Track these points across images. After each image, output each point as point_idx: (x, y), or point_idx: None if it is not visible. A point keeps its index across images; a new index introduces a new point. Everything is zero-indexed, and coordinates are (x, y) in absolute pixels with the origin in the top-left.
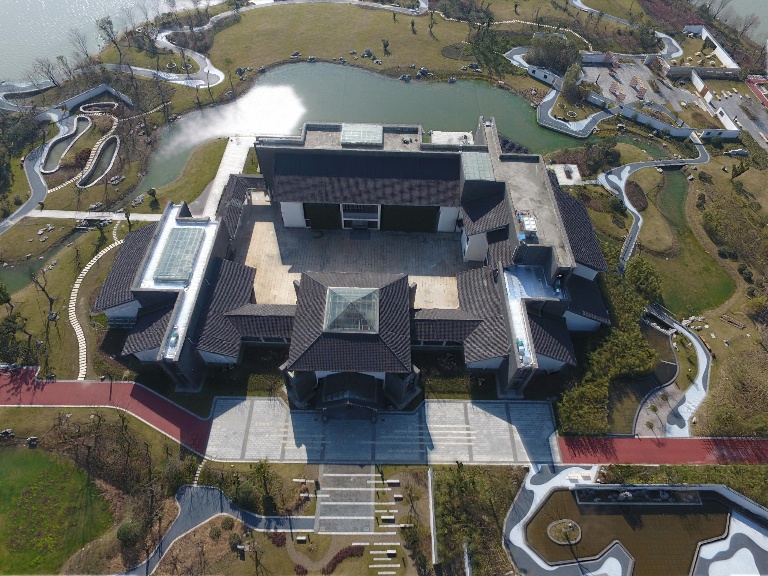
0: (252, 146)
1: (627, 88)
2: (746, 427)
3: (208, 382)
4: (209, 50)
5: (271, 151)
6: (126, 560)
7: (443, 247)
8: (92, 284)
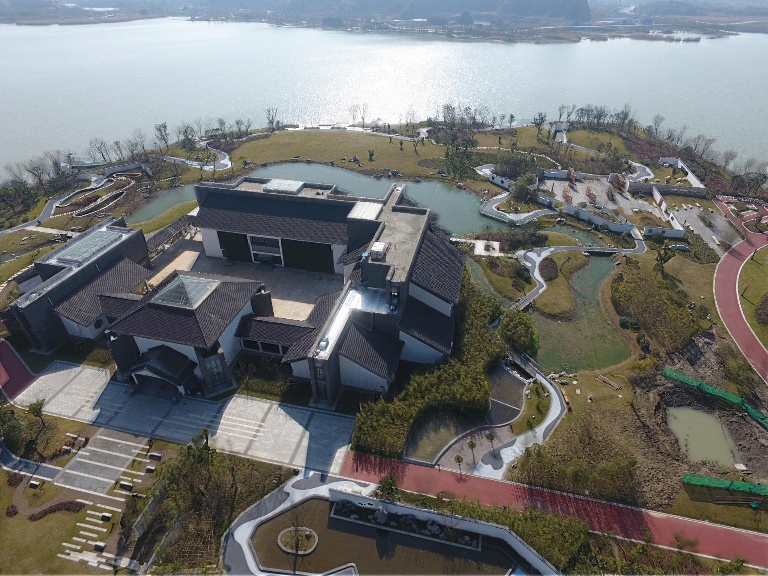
0: None
1: (582, 196)
2: (560, 471)
3: (59, 348)
4: (233, 151)
5: (205, 190)
6: None
7: (333, 285)
8: None
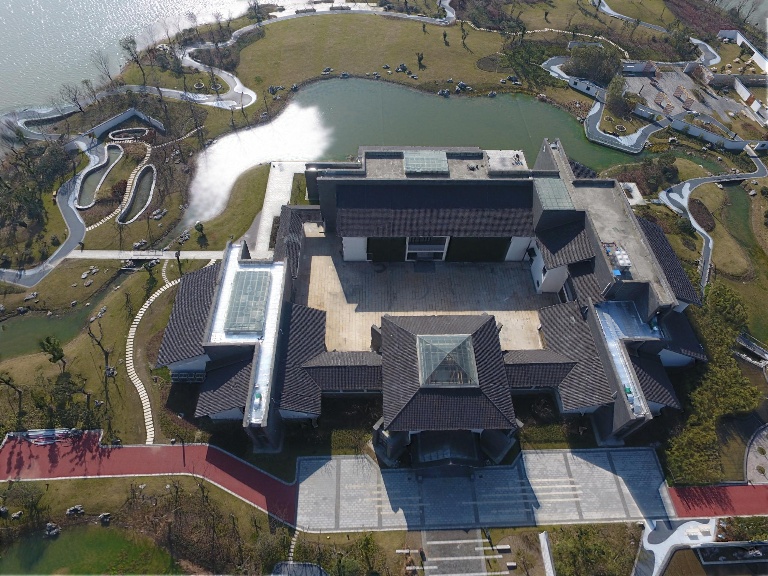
0: (296, 172)
1: (671, 98)
2: None
3: (288, 441)
4: (236, 68)
5: (332, 183)
6: None
7: (513, 278)
8: (147, 333)
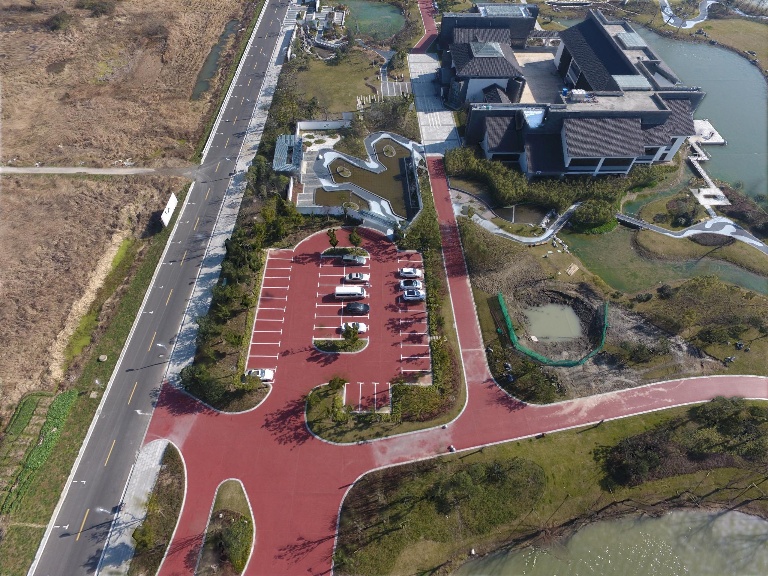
0: None
1: None
2: None
3: None
4: (715, 19)
5: None
6: (367, 42)
7: None
8: None
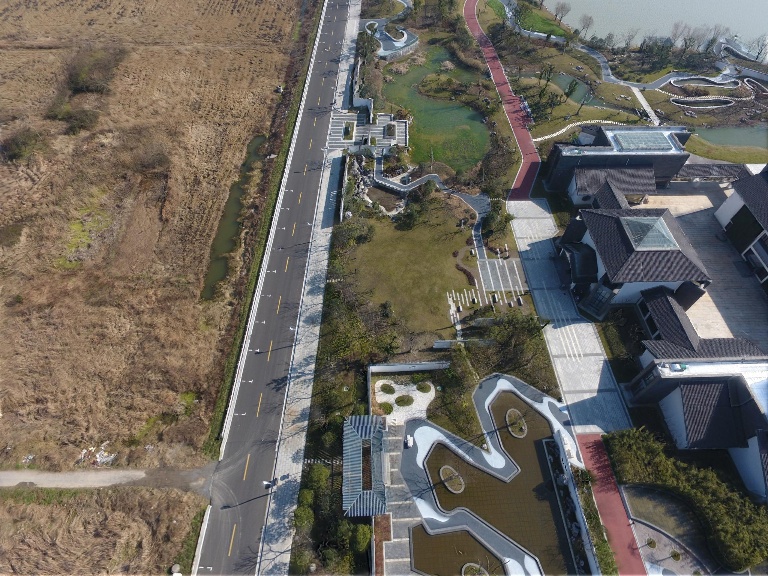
0: None
1: None
2: None
3: (554, 193)
4: None
5: None
6: (447, 180)
7: None
8: None
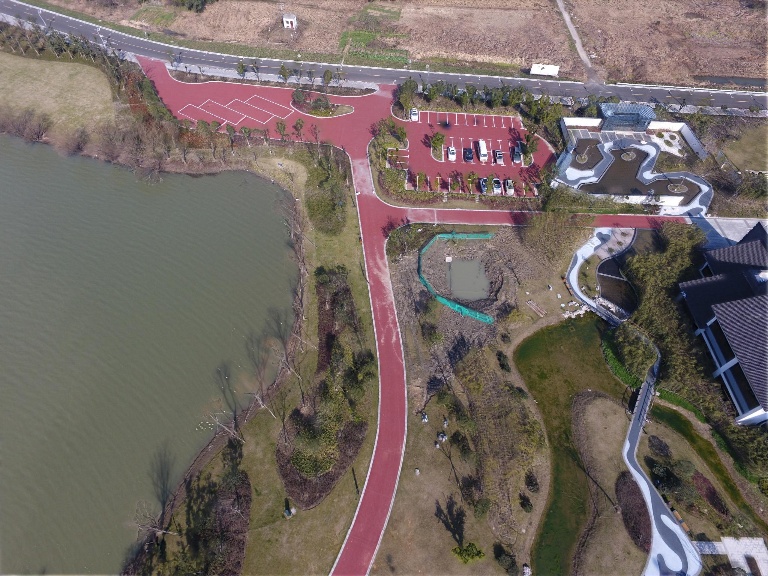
0: None
1: None
2: None
3: None
4: None
5: None
6: None
7: None
8: None
